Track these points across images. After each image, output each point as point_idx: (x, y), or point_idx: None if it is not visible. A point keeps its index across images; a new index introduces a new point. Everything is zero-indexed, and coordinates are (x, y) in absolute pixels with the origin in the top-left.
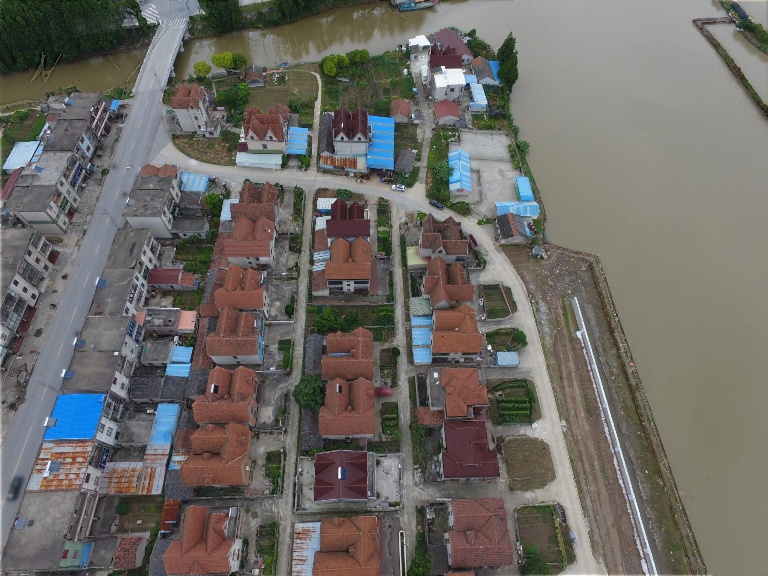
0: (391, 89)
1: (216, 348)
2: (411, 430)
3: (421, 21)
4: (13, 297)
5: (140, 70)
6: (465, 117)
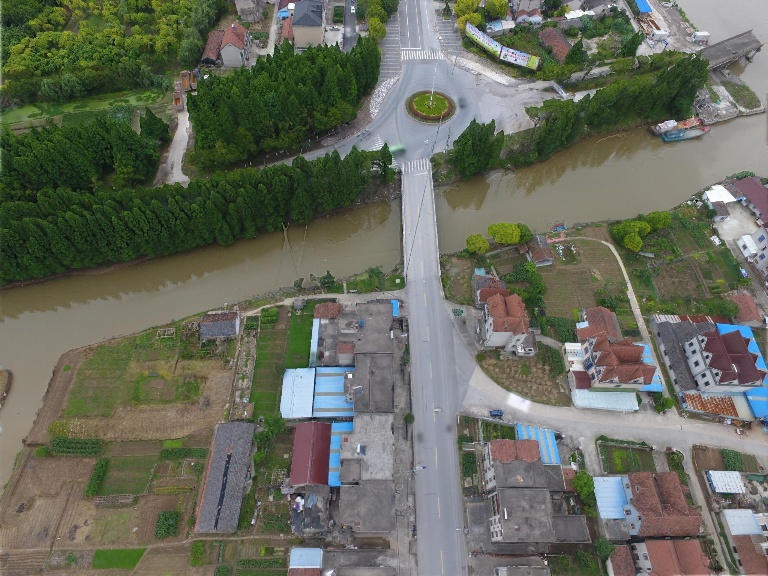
0: (710, 269)
1: None
2: None
3: (689, 153)
4: None
5: (405, 247)
6: None
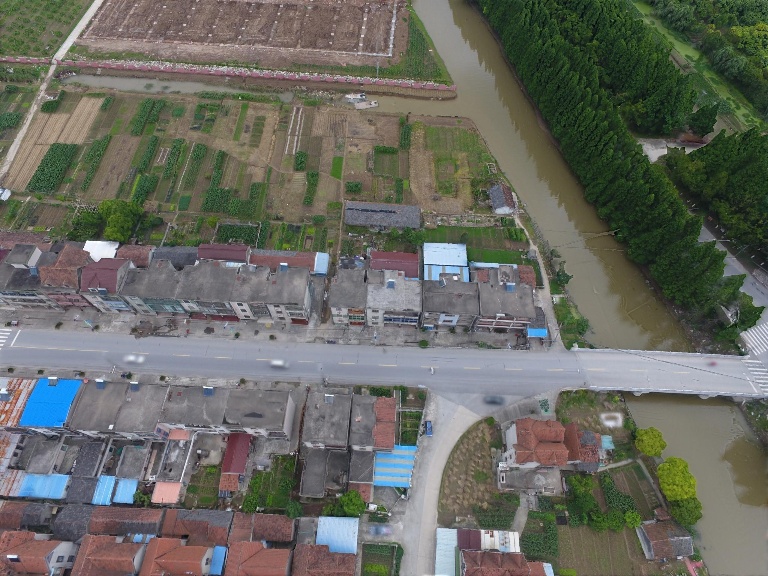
0: None
1: (83, 548)
2: None
3: None
4: (226, 306)
5: (620, 349)
6: None
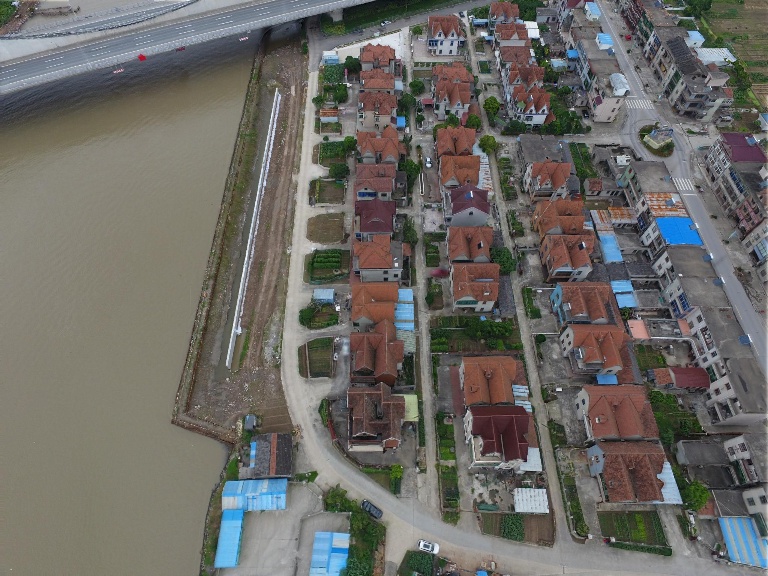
0: None
1: None
2: None
3: None
4: None
5: None
6: None
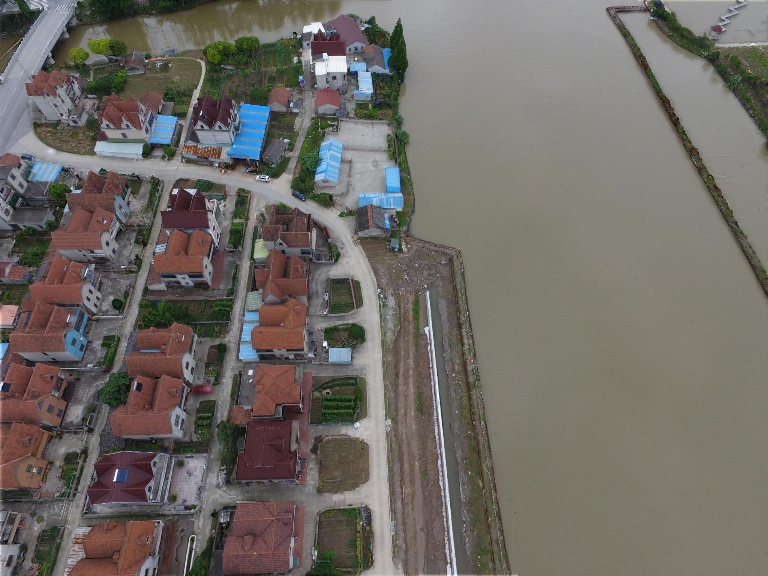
0: (277, 77)
1: (20, 344)
2: (218, 430)
3: (326, 8)
4: None
5: None
6: (346, 106)
